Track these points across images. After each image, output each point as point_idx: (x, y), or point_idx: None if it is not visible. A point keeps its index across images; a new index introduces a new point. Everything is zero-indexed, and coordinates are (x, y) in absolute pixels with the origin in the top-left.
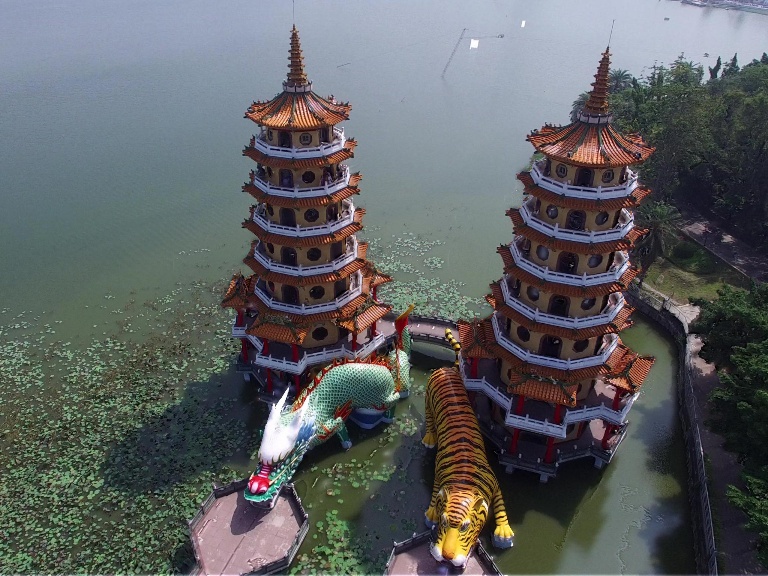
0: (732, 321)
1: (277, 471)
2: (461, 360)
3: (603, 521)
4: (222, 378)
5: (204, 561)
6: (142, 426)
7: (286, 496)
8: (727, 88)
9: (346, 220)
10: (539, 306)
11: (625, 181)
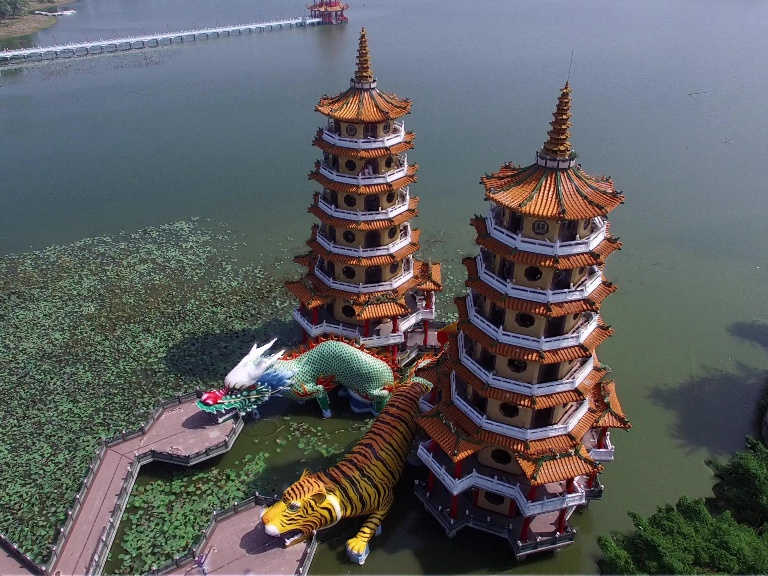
0: None
1: (232, 396)
2: None
3: None
4: (298, 324)
5: (150, 431)
6: (219, 332)
7: (236, 421)
8: None
9: (382, 214)
10: (475, 349)
11: (570, 240)
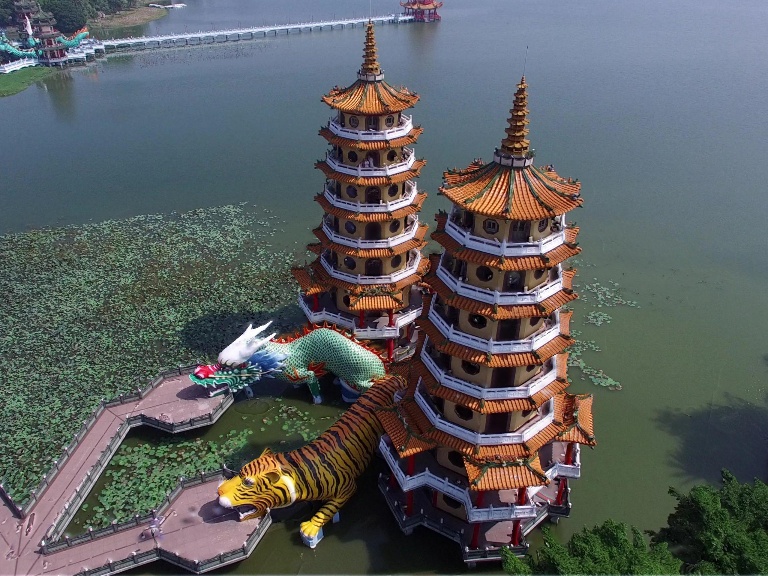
0: None
1: (224, 372)
2: None
3: None
4: None
5: (147, 397)
6: (237, 312)
7: None
8: None
9: (382, 207)
10: None
11: (521, 242)
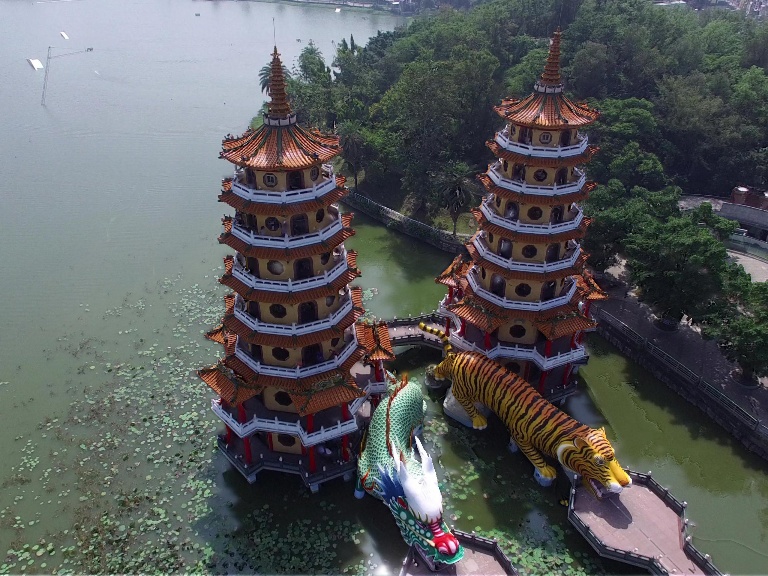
0: (591, 226)
1: None
2: (463, 341)
3: (617, 406)
4: (222, 497)
5: None
6: None
7: None
8: (397, 62)
9: (344, 251)
10: (539, 260)
11: None
